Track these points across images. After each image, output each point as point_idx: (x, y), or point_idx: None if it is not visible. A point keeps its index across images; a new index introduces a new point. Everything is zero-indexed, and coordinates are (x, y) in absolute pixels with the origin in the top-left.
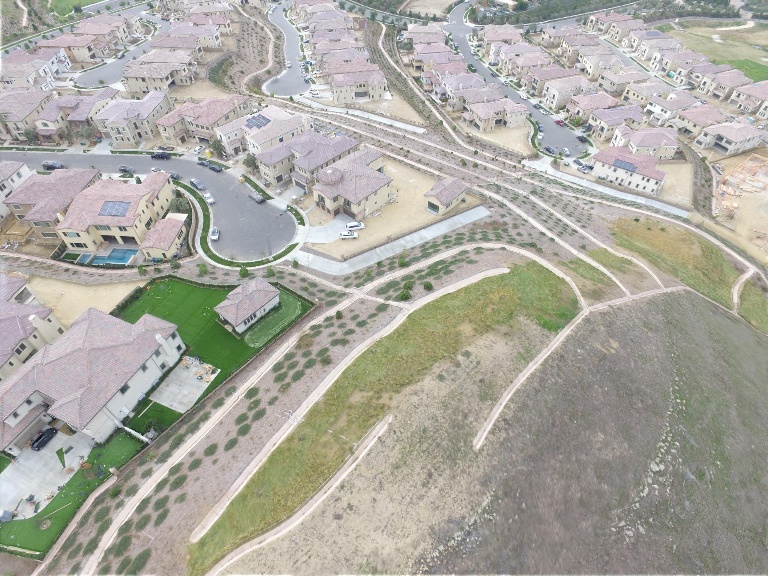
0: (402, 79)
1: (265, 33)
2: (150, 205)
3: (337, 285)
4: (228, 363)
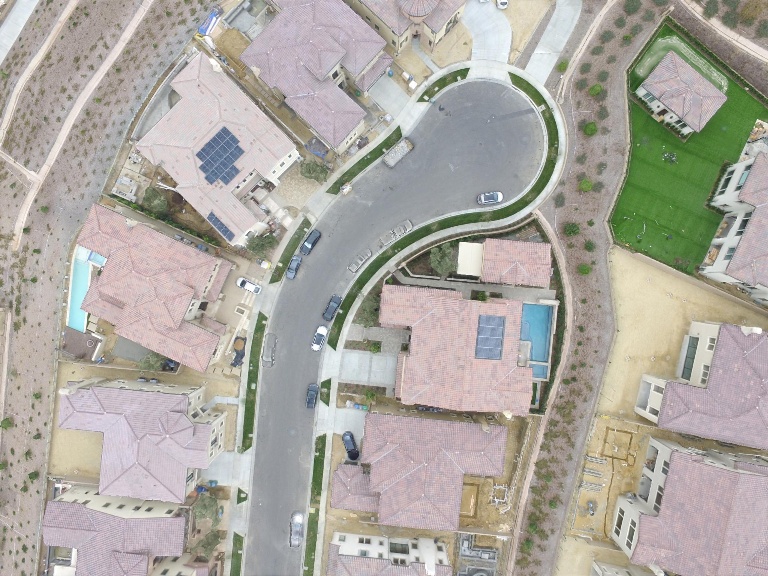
0: None
1: None
2: None
3: (604, 6)
4: (749, 112)
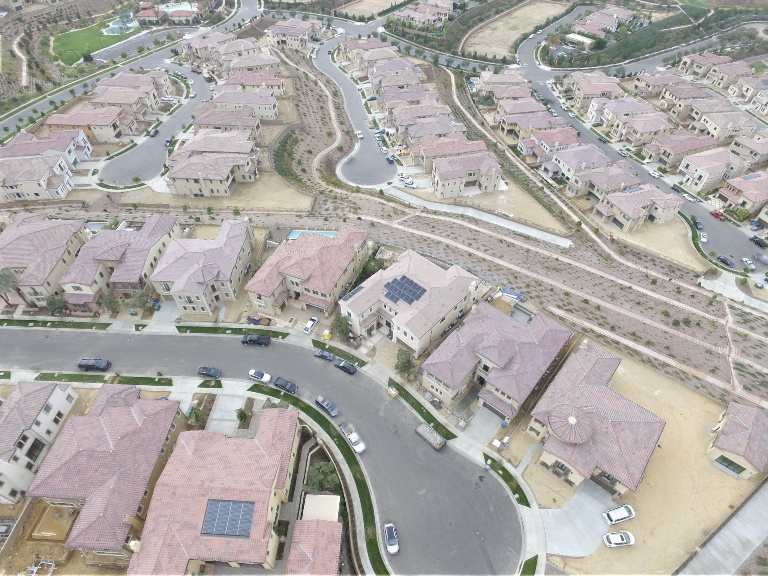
0: (500, 151)
1: (320, 89)
2: (279, 490)
3: None
4: None
